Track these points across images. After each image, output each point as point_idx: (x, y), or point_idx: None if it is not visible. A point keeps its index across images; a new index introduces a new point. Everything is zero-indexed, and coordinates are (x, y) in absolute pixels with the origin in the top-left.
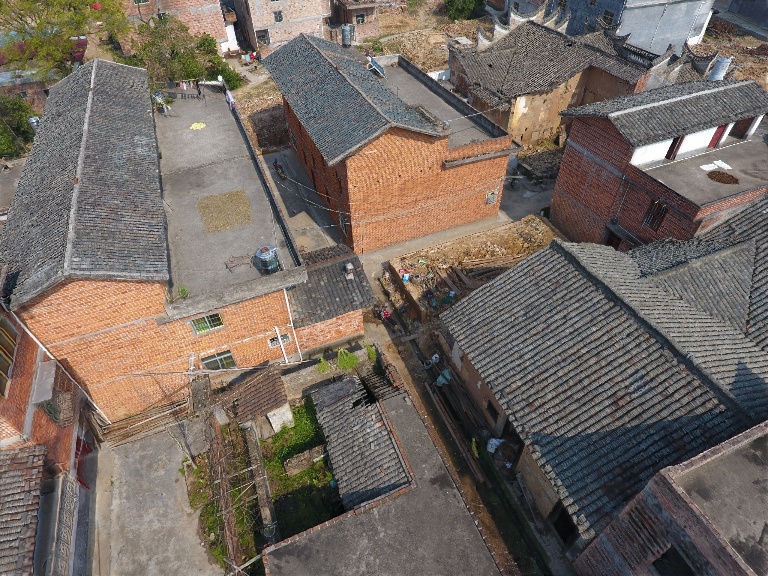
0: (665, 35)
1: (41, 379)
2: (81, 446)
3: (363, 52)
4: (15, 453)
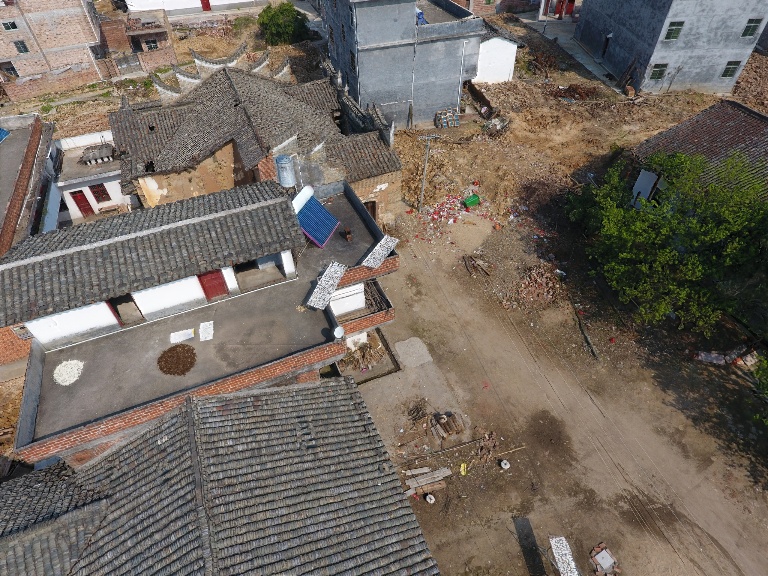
0: (428, 79)
1: None
2: None
3: (129, 87)
4: None
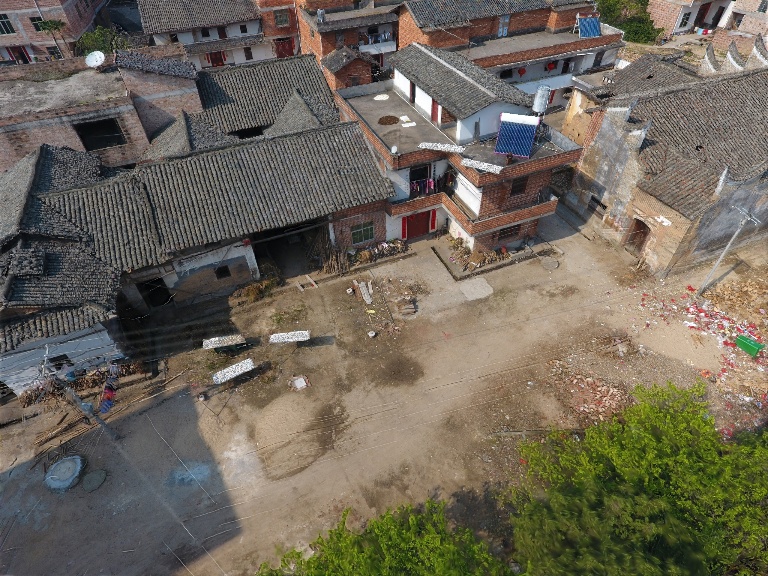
0: None
1: (281, 7)
2: (278, 41)
3: None
4: (259, 13)
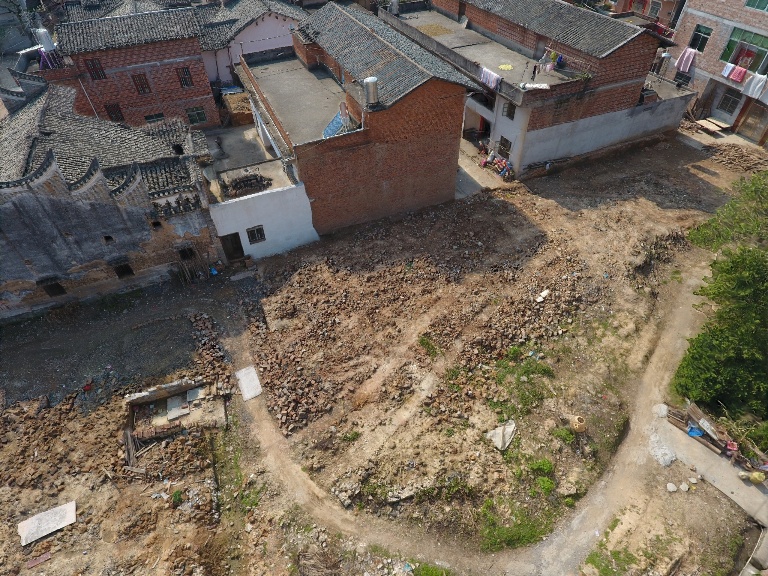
0: None
1: None
2: None
3: None
4: None
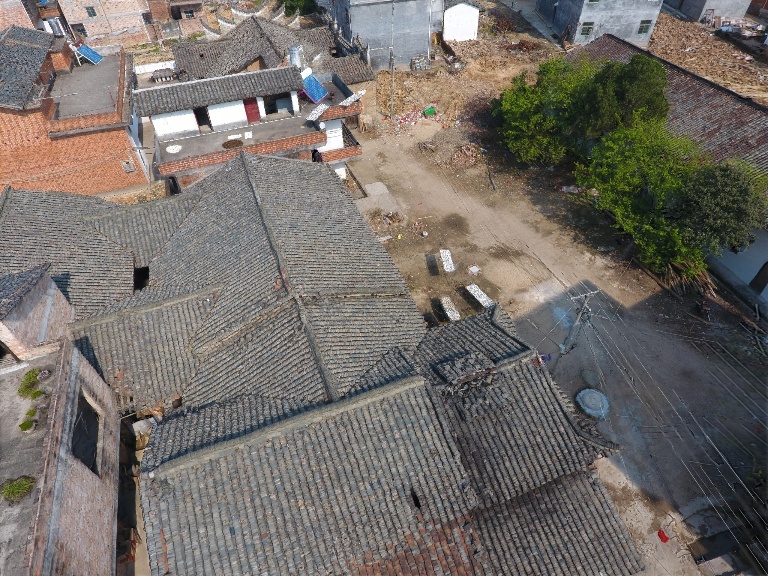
0: (404, 30)
1: None
2: None
3: None
4: None
